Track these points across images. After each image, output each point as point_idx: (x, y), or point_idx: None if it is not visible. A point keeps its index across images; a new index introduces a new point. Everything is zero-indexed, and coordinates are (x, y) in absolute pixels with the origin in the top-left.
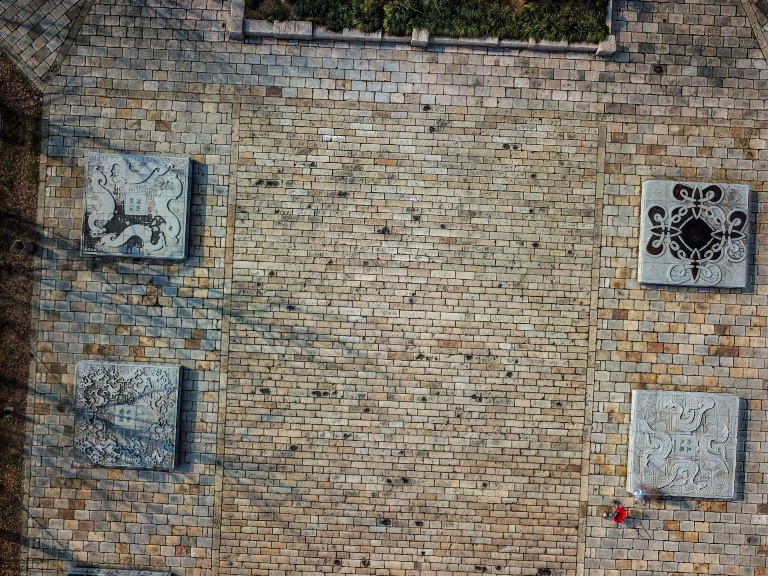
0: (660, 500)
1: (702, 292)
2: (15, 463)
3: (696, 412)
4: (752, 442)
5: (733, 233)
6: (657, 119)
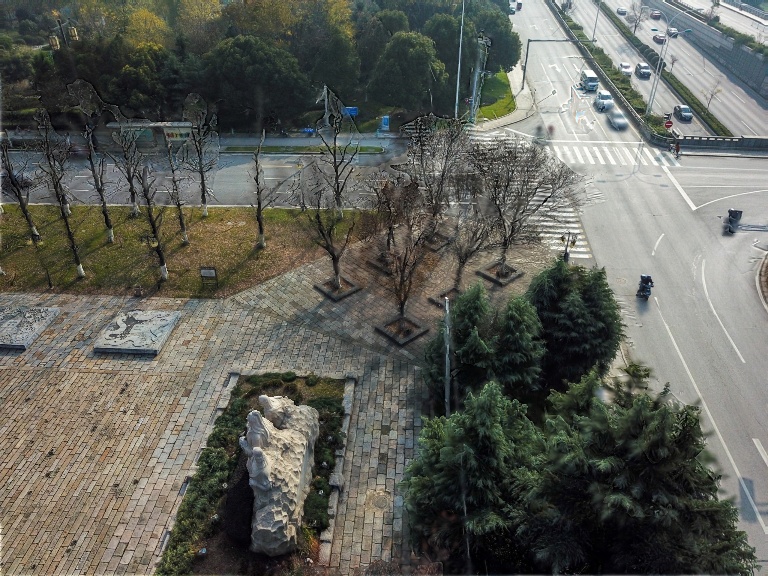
0: None
1: None
2: (21, 290)
3: None
4: None
5: None
6: None
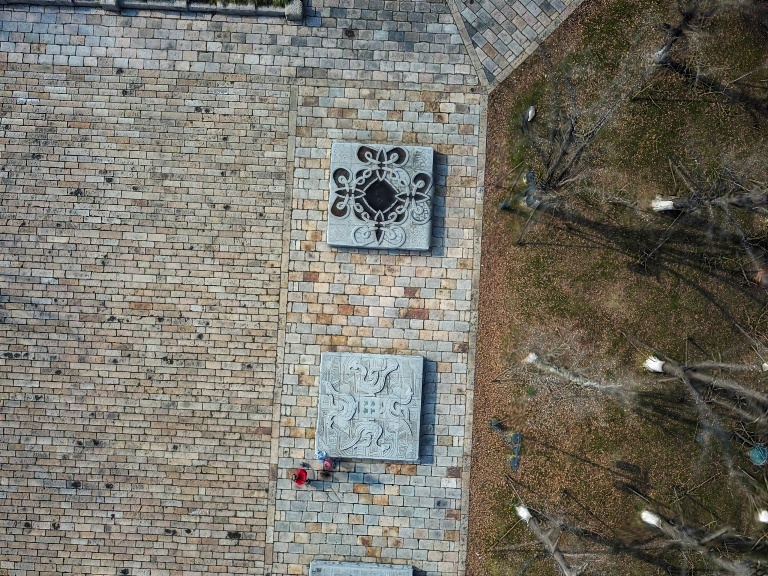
0: (350, 463)
1: (392, 255)
2: None
3: (380, 374)
4: (442, 405)
5: (417, 195)
6: (348, 83)
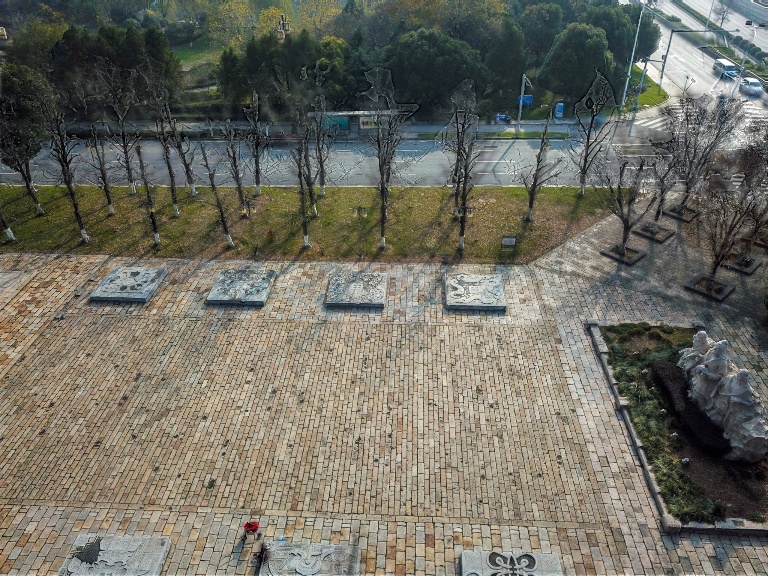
0: (253, 575)
1: None
2: (334, 259)
3: None
4: None
5: None
6: (621, 573)
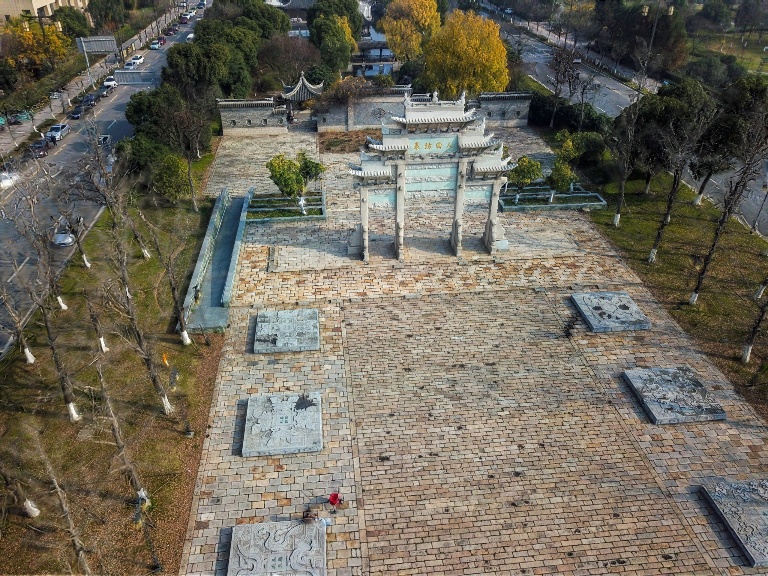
0: None
1: None
2: None
3: None
4: None
5: None
6: None
